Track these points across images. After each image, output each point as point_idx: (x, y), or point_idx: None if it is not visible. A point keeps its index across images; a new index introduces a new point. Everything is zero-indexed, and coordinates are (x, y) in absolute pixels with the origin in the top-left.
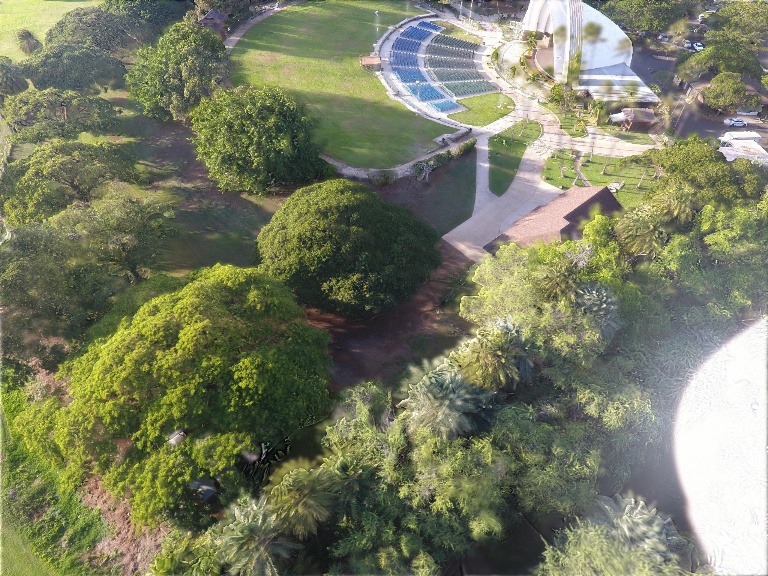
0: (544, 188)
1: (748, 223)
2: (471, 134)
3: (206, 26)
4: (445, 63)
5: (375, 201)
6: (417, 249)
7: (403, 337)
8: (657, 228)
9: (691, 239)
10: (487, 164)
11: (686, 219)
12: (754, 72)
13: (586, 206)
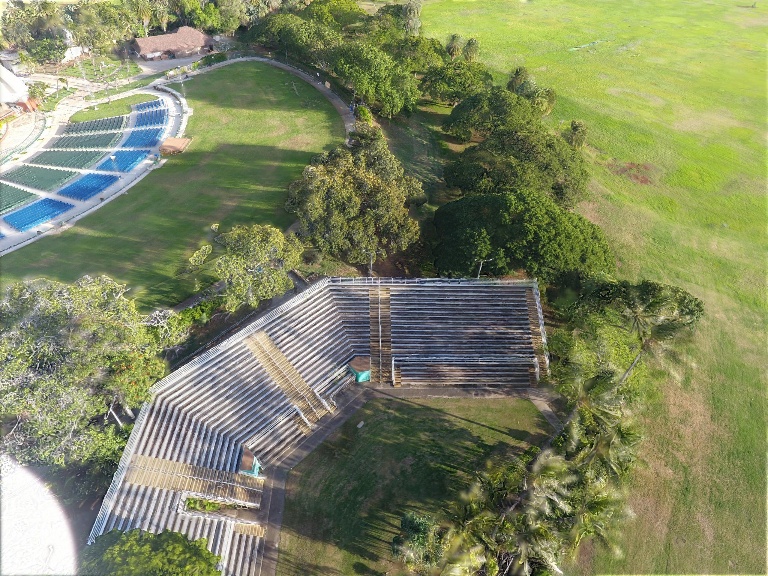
0: (149, 68)
1: None
2: None
3: None
4: (77, 154)
5: None
6: None
7: None
8: None
9: None
10: None
11: None
12: None
13: None
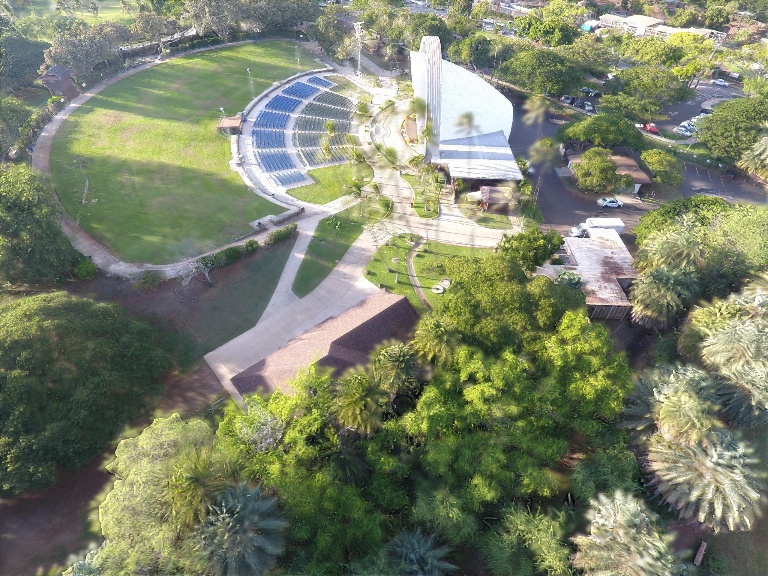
0: (360, 286)
1: (513, 376)
2: (303, 214)
3: (48, 83)
4: (317, 125)
5: (83, 325)
6: (119, 392)
7: (80, 513)
8: (364, 397)
9: (446, 393)
10: (302, 255)
11: (444, 365)
12: (634, 146)
13: (369, 325)
